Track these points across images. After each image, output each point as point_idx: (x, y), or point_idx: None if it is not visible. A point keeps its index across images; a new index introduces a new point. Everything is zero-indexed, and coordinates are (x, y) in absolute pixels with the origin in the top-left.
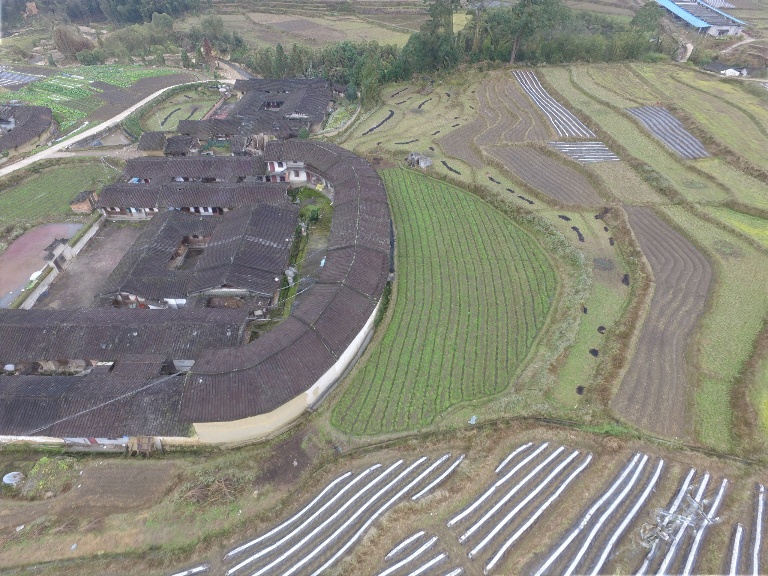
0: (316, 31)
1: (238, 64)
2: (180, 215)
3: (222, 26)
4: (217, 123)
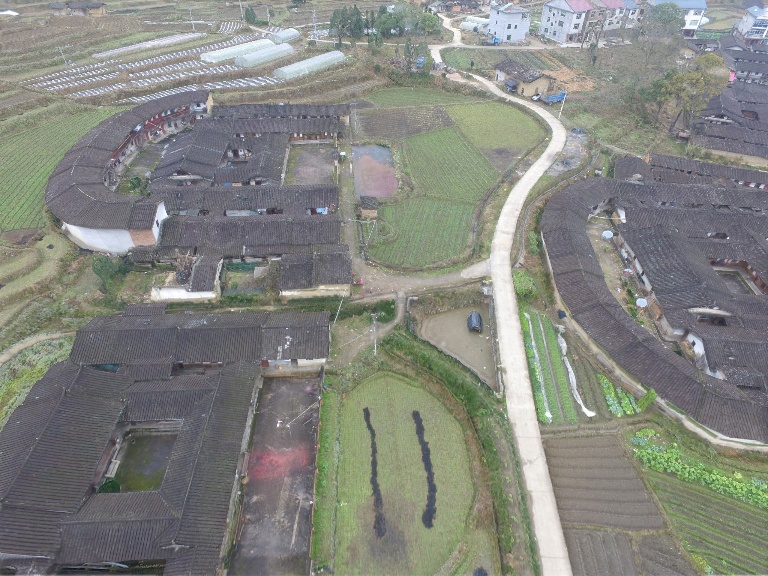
0: None
1: None
2: None
3: None
4: (256, 322)
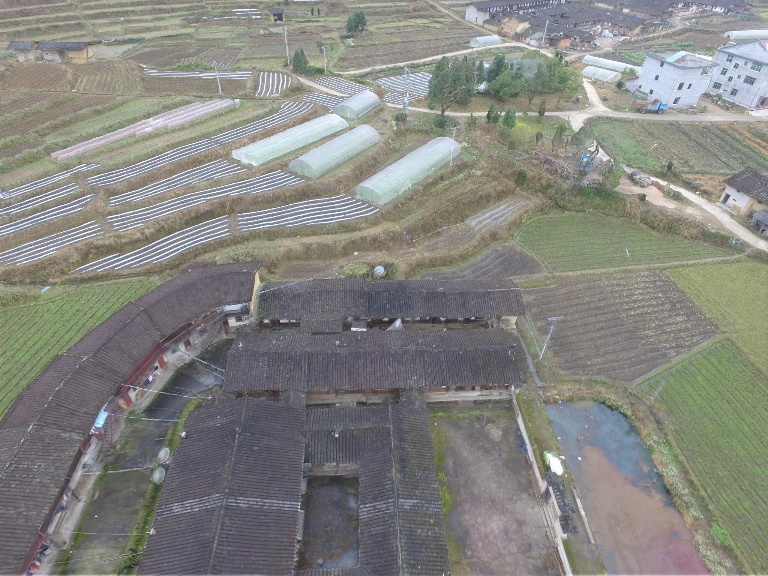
0: None
1: None
2: None
3: None
4: None
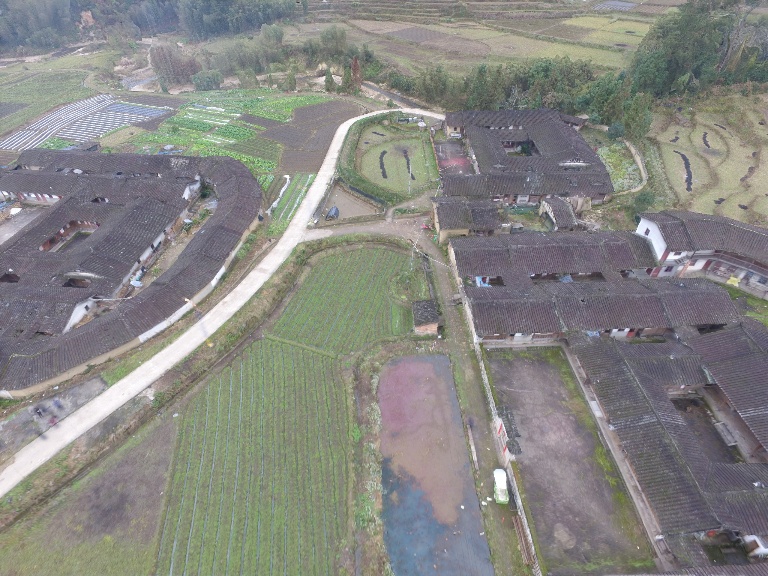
0: (449, 41)
1: (374, 83)
2: (625, 349)
3: (345, 38)
4: (494, 180)
